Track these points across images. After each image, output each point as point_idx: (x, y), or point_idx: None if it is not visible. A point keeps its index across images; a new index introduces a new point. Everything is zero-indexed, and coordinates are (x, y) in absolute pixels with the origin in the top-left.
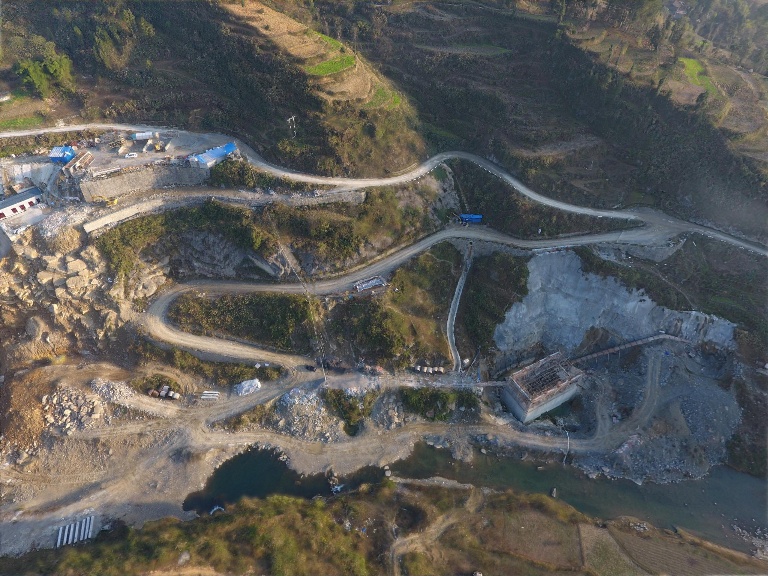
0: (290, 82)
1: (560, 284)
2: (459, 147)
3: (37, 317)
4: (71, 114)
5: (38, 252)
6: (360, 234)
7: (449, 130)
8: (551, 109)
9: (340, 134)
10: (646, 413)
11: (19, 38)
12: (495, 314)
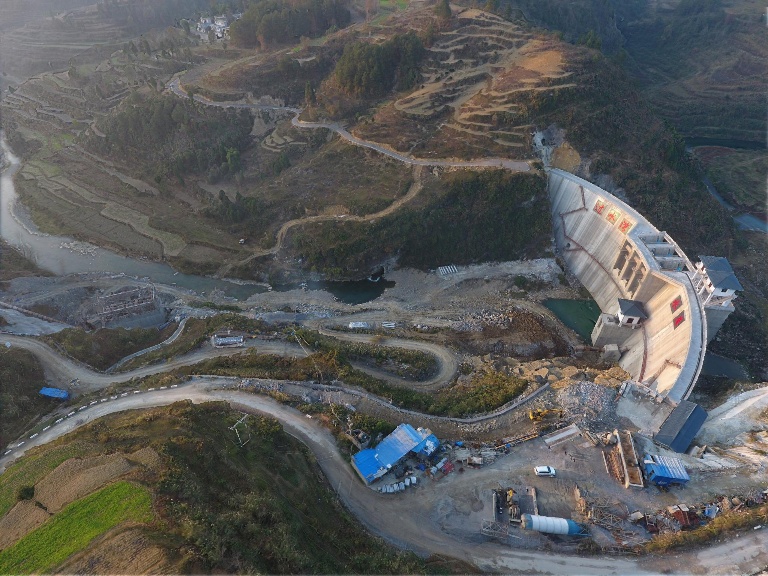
0: None
1: None
2: None
3: None
4: None
5: None
6: None
7: None
8: None
9: None
10: (80, 284)
11: None
12: None
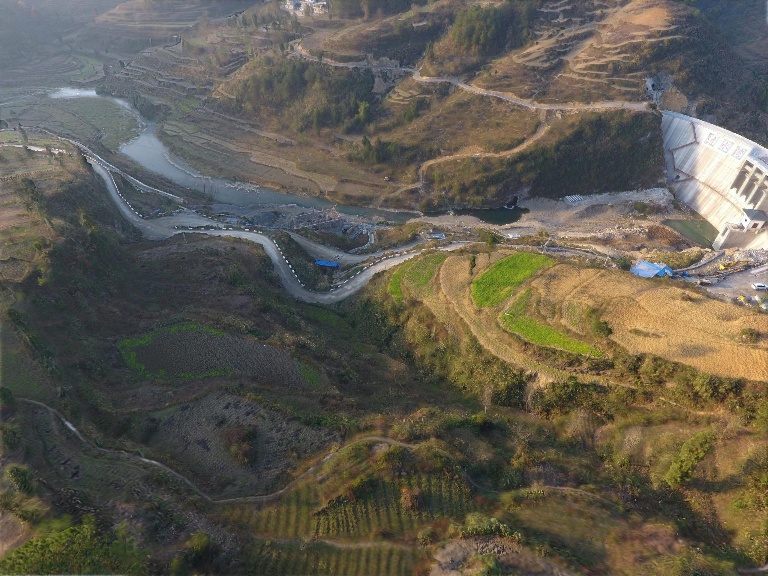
0: None
1: None
2: None
3: None
4: None
5: None
6: None
7: None
8: None
9: None
10: (266, 210)
11: None
12: None
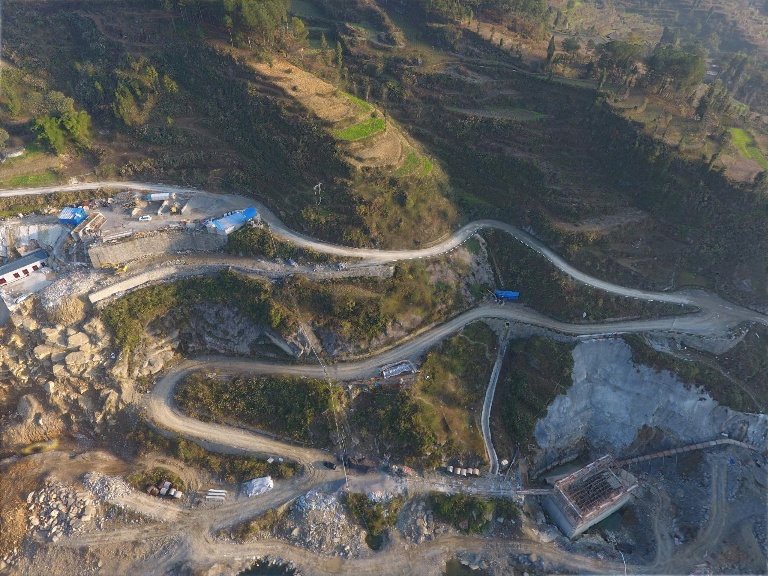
0: (316, 146)
1: (608, 375)
2: (492, 215)
3: (31, 395)
4: (85, 171)
5: (38, 323)
6: (388, 313)
7: (481, 197)
8: (591, 179)
9: (368, 203)
10: (714, 536)
11: (37, 94)
12: (536, 407)
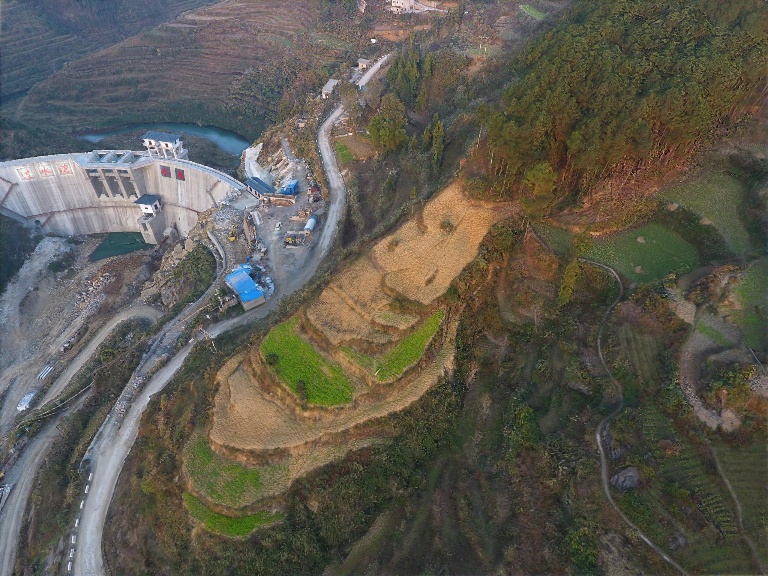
0: None
1: None
2: None
3: None
4: (354, 172)
5: None
6: None
7: None
8: None
9: None
10: None
11: (392, 96)
12: None
